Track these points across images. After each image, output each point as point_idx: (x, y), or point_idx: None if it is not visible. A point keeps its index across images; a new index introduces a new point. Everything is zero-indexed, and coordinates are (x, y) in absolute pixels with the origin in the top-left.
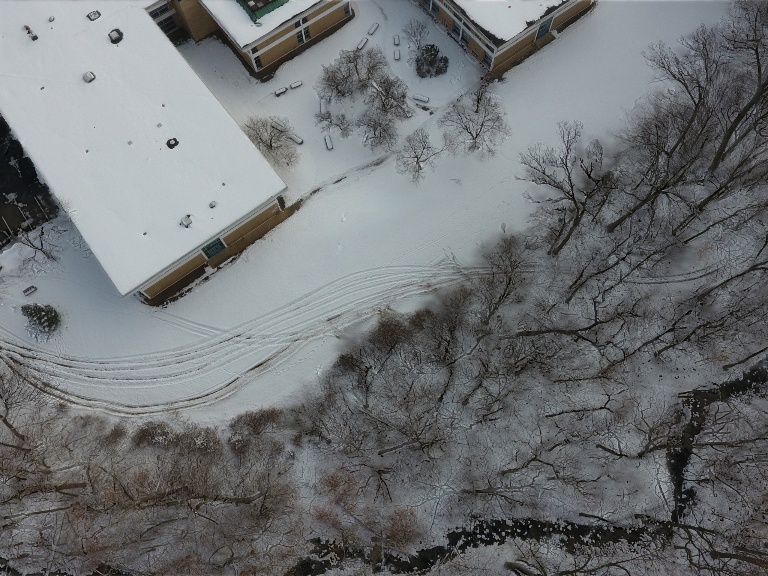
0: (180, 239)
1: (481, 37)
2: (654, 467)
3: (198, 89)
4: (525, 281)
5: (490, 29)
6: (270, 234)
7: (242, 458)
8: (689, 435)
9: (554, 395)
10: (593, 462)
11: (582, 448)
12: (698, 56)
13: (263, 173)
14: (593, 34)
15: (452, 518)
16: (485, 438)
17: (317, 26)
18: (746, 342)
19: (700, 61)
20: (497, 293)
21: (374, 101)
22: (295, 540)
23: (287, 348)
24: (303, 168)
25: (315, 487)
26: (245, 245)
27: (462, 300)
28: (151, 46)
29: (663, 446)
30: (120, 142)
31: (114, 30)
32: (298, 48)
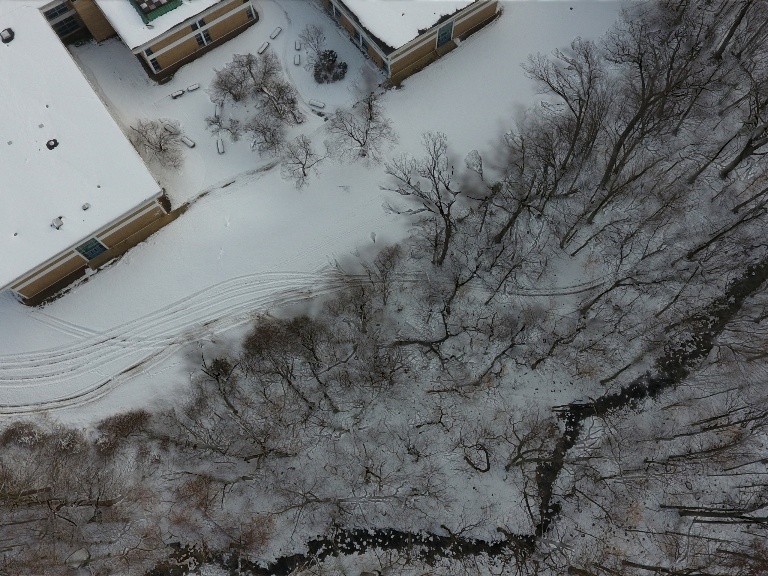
0: (50, 240)
1: (372, 44)
2: (522, 480)
3: (83, 90)
4: (406, 290)
5: (381, 36)
6: (153, 237)
7: (107, 460)
8: (561, 449)
9: (426, 405)
10: (457, 474)
11: (449, 459)
12: (574, 69)
13: (139, 176)
14: (496, 43)
15: (314, 526)
16: (353, 447)
17: (218, 29)
18: (626, 357)
19: (584, 74)
20: (377, 302)
21: (265, 106)
22: (153, 544)
23: (162, 351)
24: (192, 171)
25: (178, 491)
26: (127, 247)
27: (342, 308)
28: (41, 46)
29: (533, 460)
30: (0, 142)
31: (6, 29)
32: (199, 51)
